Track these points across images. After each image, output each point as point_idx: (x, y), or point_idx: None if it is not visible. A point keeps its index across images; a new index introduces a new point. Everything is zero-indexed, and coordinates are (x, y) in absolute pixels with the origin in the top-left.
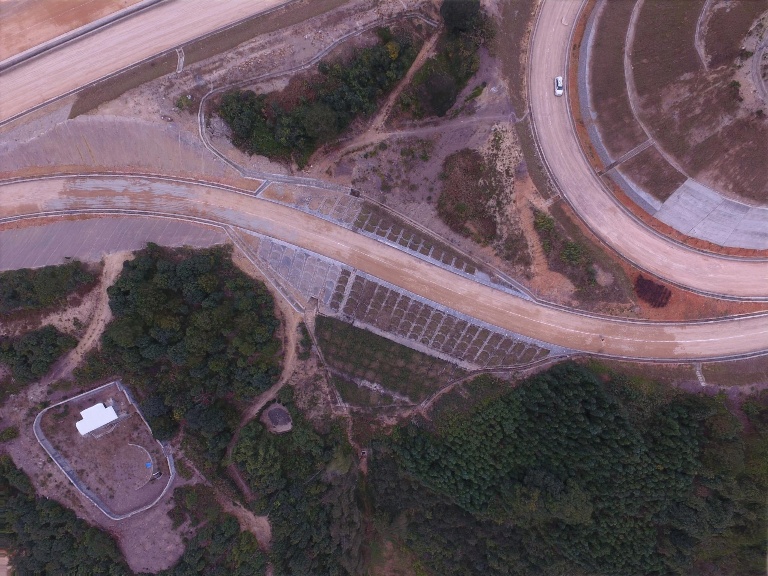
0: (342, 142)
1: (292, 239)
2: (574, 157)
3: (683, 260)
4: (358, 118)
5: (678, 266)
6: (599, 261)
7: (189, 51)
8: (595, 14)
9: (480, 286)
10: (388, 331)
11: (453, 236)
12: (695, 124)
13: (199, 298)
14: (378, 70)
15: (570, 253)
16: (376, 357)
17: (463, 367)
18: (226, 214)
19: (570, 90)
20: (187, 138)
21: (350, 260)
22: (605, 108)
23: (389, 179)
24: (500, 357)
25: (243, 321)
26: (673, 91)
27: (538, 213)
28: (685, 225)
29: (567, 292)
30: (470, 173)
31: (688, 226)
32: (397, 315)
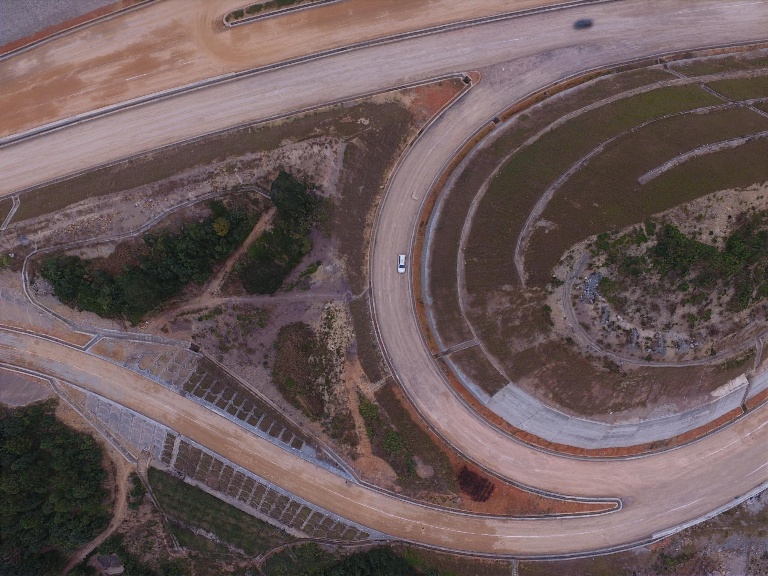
0: (178, 302)
1: (119, 397)
2: (412, 337)
3: (511, 452)
4: (192, 283)
5: (506, 458)
6: (420, 453)
7: (25, 199)
8: (441, 195)
9: (305, 462)
10: (218, 491)
11: (285, 405)
12: (515, 334)
13: (8, 461)
14: (208, 243)
15: (390, 444)
16: (208, 512)
17: (291, 534)
18: (54, 366)
19: (413, 268)
20: (10, 294)
21: (176, 424)
22: (439, 296)
23: (226, 340)
24: (324, 531)
25: (57, 483)
26: (496, 298)
27: (362, 399)
28: (514, 419)
29: (390, 477)
30: (300, 349)
31: (516, 421)
32: (224, 479)
